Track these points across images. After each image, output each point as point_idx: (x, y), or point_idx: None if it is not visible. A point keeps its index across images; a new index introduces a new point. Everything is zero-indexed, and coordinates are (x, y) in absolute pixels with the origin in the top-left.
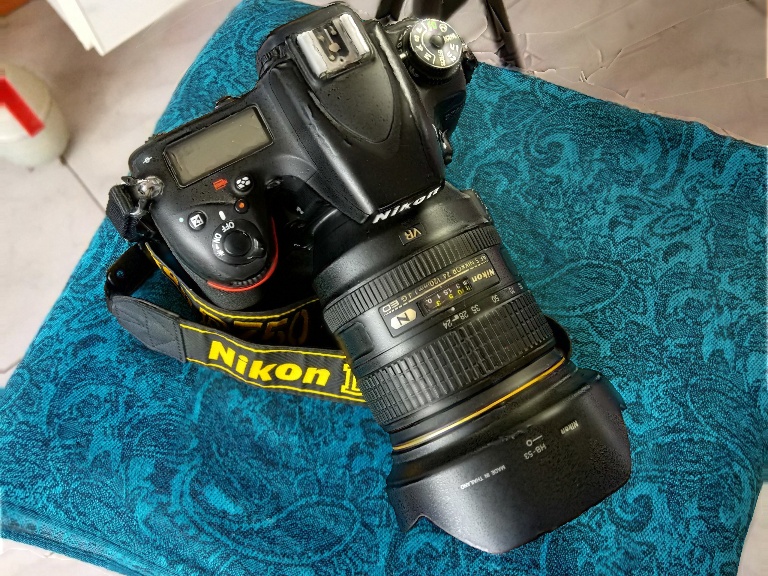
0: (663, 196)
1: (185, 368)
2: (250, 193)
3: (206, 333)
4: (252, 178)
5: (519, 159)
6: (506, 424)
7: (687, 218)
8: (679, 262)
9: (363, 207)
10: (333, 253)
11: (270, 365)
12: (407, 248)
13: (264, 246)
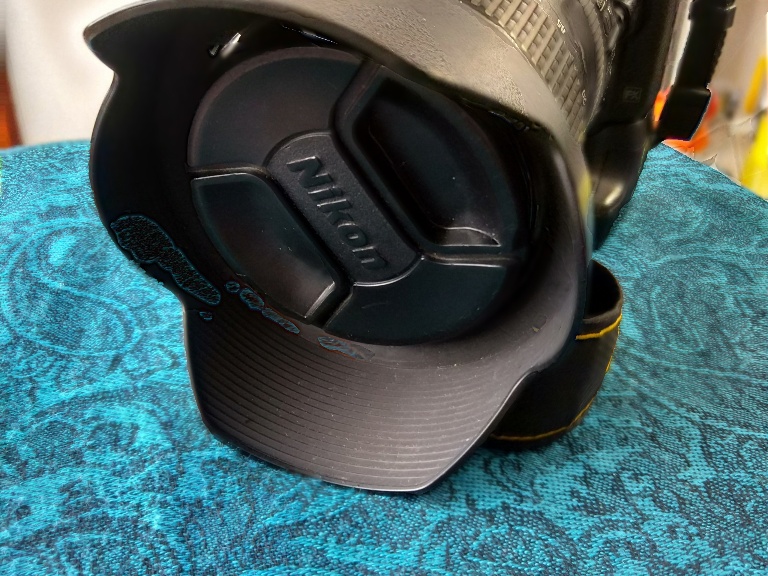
0: None
1: None
2: None
3: None
4: None
5: (765, 275)
6: None
7: None
8: None
9: None
10: None
11: None
12: None
13: None
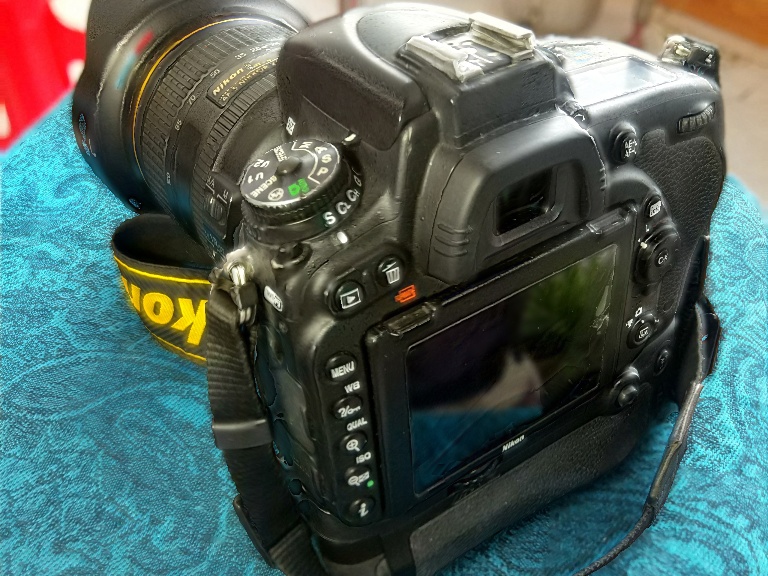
0: None
1: None
2: None
3: None
4: None
5: None
6: (216, 1)
7: None
8: None
9: None
10: None
11: None
12: None
13: None
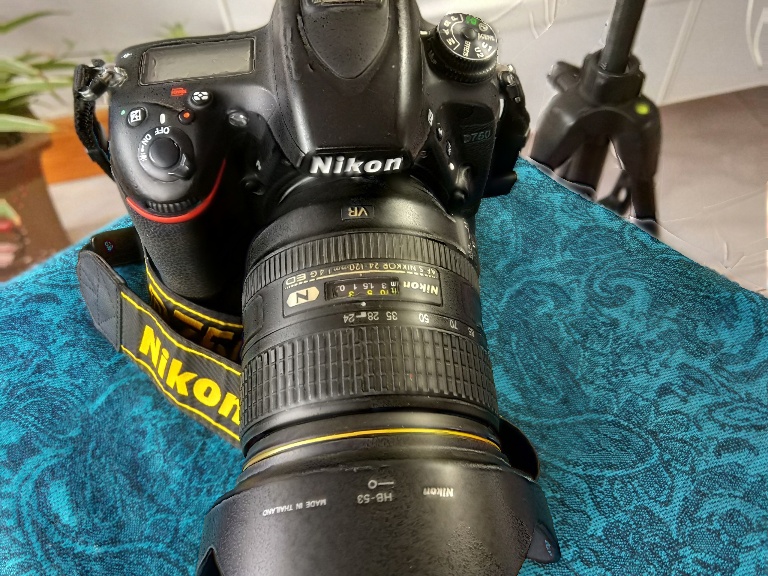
0: (739, 382)
1: (116, 357)
2: (203, 110)
3: (142, 311)
4: (213, 97)
5: (576, 288)
6: (360, 457)
7: (763, 416)
8: (735, 462)
9: (302, 143)
10: (272, 219)
11: (190, 373)
12: (344, 224)
13: (191, 166)
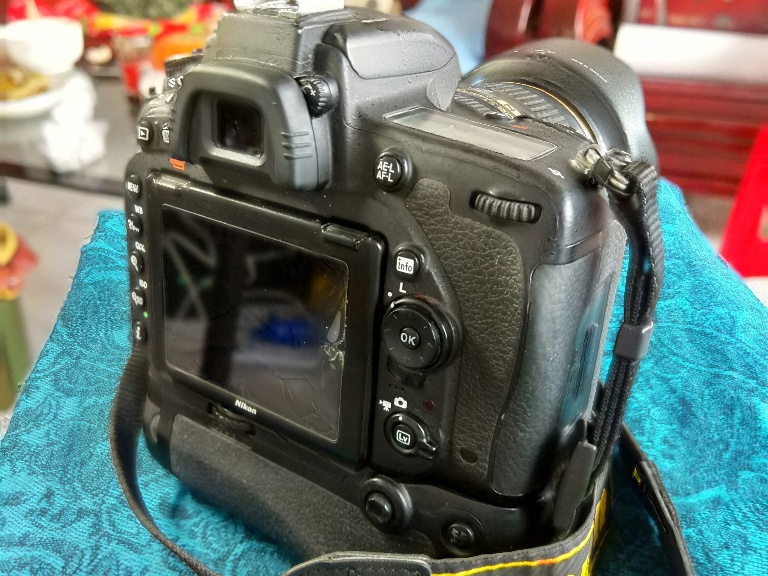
0: None
1: None
2: None
3: None
4: None
5: None
6: (537, 71)
7: None
8: None
9: None
10: None
11: None
12: None
13: None
